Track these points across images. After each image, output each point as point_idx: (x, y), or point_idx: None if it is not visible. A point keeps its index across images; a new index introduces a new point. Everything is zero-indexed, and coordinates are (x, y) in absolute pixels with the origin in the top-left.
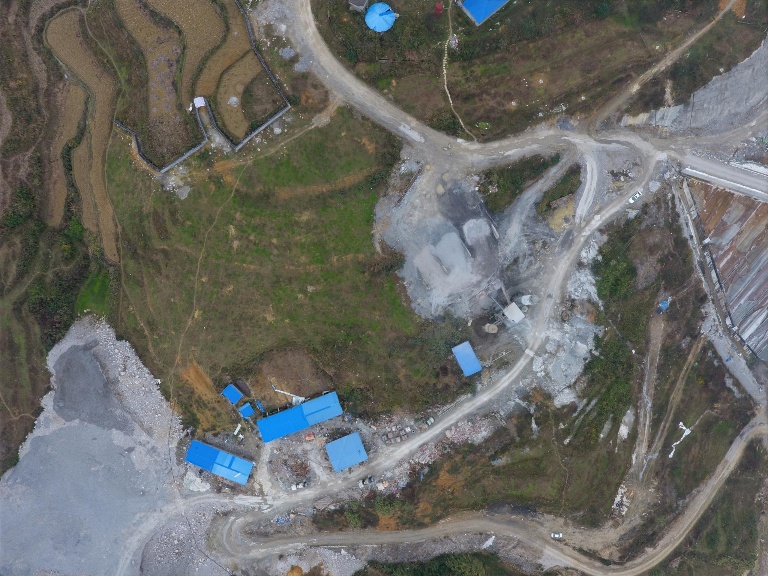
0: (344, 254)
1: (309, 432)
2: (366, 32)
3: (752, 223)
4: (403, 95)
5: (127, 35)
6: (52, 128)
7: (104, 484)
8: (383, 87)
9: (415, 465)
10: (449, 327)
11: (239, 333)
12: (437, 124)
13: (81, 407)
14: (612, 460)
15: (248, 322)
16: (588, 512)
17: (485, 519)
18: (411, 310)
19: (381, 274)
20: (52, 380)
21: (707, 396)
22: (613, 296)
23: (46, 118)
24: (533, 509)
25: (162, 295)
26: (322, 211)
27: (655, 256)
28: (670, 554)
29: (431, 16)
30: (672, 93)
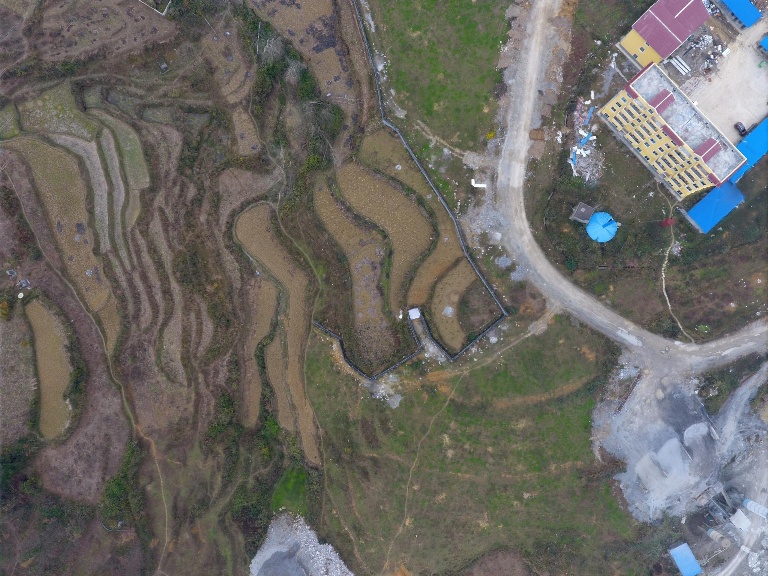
0: (563, 462)
1: None
2: (590, 244)
3: None
4: (620, 299)
5: (328, 238)
6: (246, 327)
7: None
8: (601, 293)
9: None
10: (667, 529)
11: (451, 540)
12: (656, 329)
13: None
14: None
15: (460, 528)
16: None
17: None
18: (628, 513)
19: (600, 480)
20: None
21: None
22: None
23: (241, 319)
24: None
25: (370, 501)
26: (538, 418)
27: None
28: None
29: (655, 226)
30: None
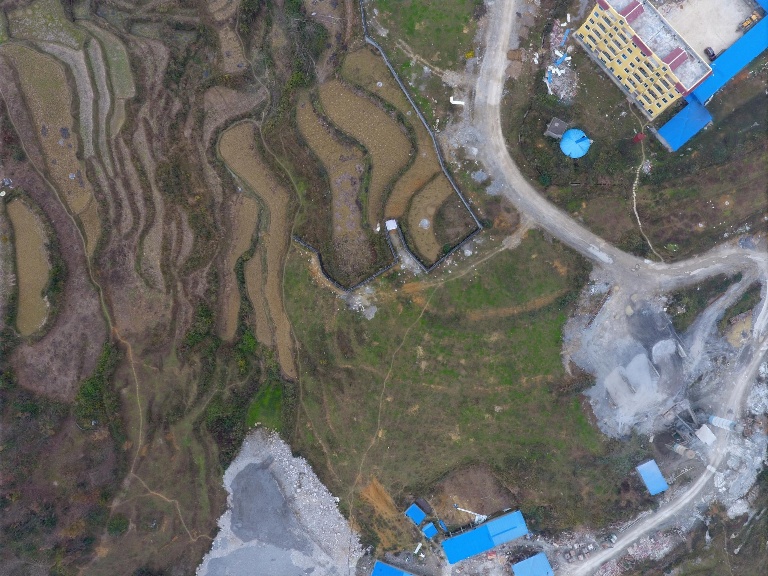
0: (534, 375)
1: (491, 550)
2: (563, 159)
3: None
4: (592, 217)
5: (310, 153)
6: (226, 241)
7: None
8: (573, 210)
9: None
10: (635, 446)
11: (423, 452)
12: (626, 246)
13: (259, 527)
14: None
15: (432, 441)
16: None
17: None
18: (597, 429)
19: (570, 394)
20: (229, 499)
21: None
22: None
23: (222, 232)
24: None
25: (344, 413)
26: (511, 332)
27: None
28: None
29: (626, 143)
30: None
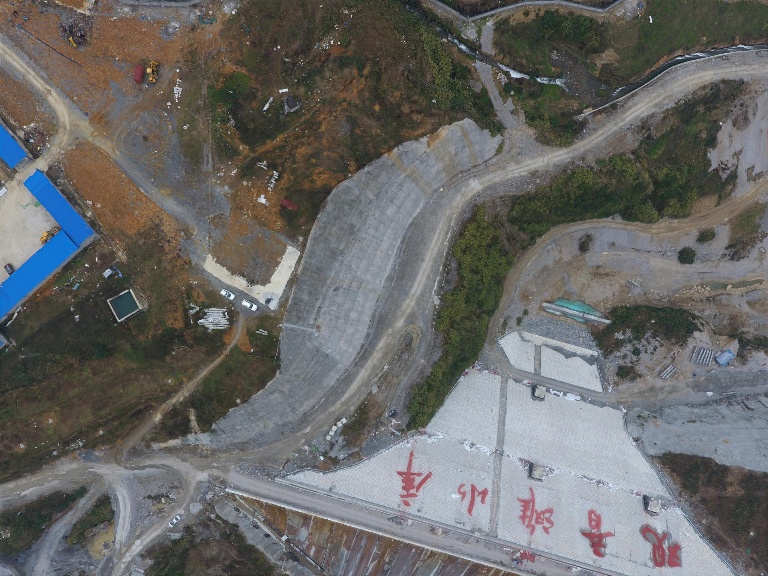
0: None
1: None
2: None
3: (316, 528)
4: None
5: None
6: None
7: None
8: None
9: None
10: None
11: None
12: None
13: None
14: None
15: None
16: None
17: None
18: None
19: None
20: None
21: None
22: None
23: None
24: None
25: None
26: None
27: (215, 568)
28: None
29: None
30: None
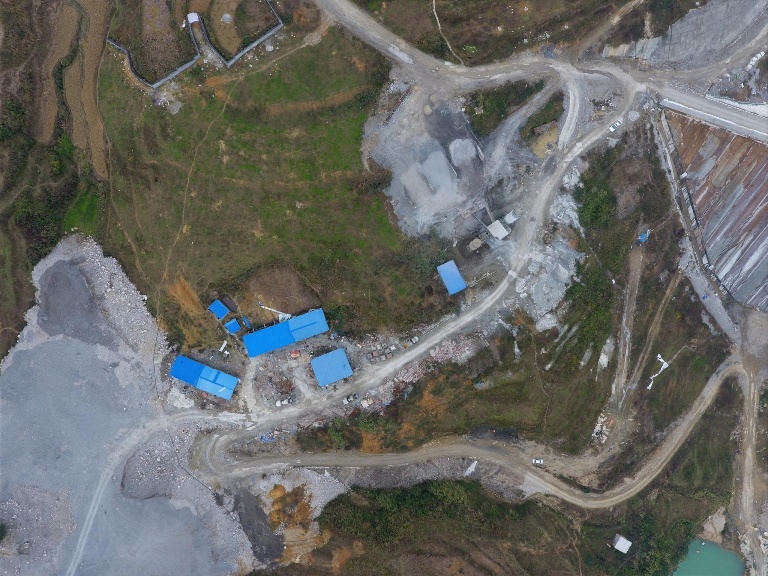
0: (333, 171)
1: (295, 349)
2: None
3: (727, 157)
4: (393, 17)
5: None
6: (44, 46)
7: (87, 399)
8: (373, 9)
9: (399, 383)
10: (434, 246)
11: (227, 249)
12: (425, 46)
13: (66, 322)
14: (592, 388)
15: (236, 238)
16: (568, 439)
17: (468, 444)
18: (398, 228)
19: (369, 191)
20: (37, 295)
21: (684, 331)
22: (594, 223)
23: (39, 35)
24: (515, 435)
25: (151, 210)
26: (312, 128)
27: (634, 186)
28: (648, 485)
29: None
30: (651, 25)
